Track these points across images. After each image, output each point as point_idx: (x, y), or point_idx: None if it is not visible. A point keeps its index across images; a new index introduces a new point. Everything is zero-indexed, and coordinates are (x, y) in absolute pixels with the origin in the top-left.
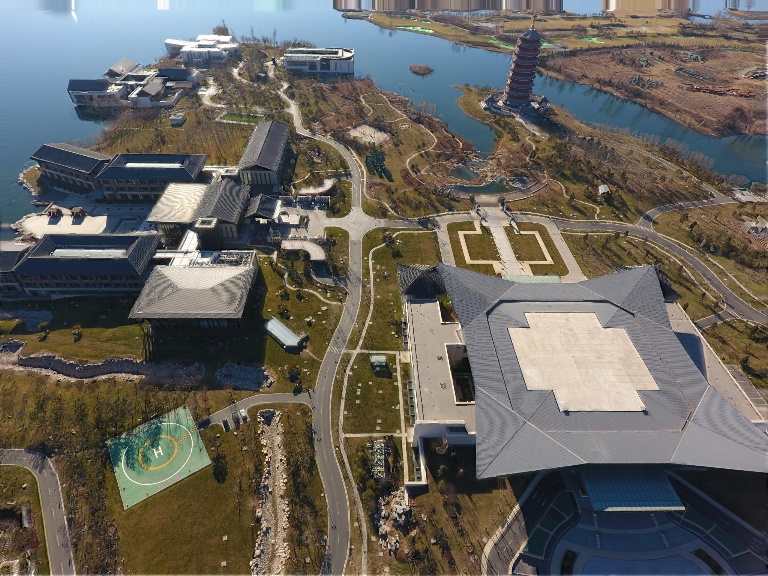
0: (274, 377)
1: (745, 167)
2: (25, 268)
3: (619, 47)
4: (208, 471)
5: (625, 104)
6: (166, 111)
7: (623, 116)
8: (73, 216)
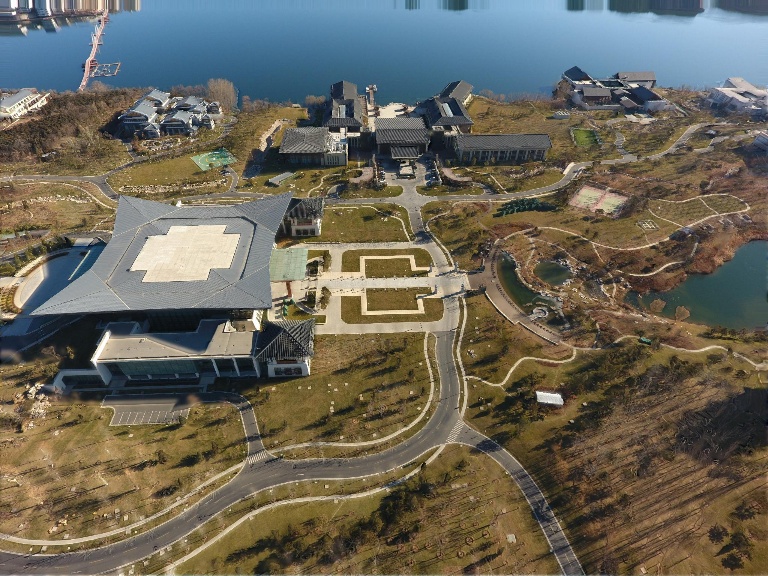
0: None
1: None
2: (328, 102)
3: None
4: None
5: None
6: (574, 110)
7: None
8: (404, 113)
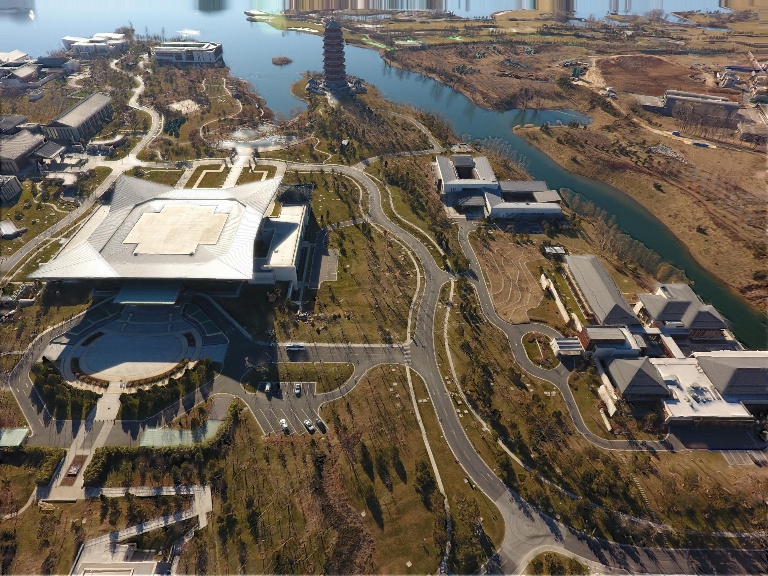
0: None
1: (495, 131)
2: None
3: (469, 43)
4: None
5: (444, 88)
6: (31, 90)
7: (444, 98)
8: None
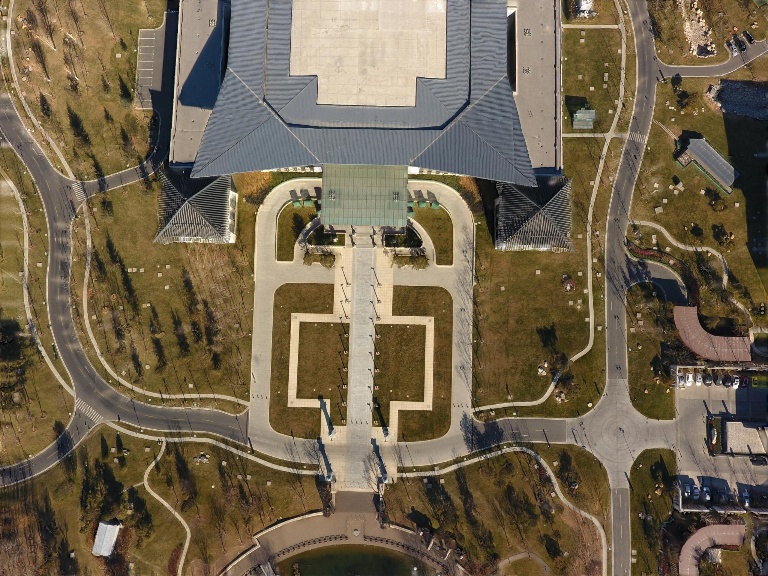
0: (708, 98)
1: None
2: None
3: None
4: None
5: None
6: None
7: None
8: None
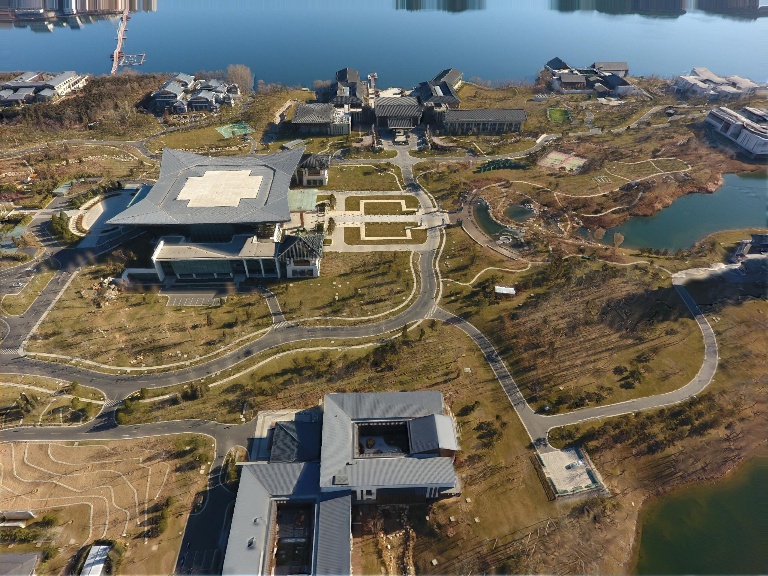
0: None
1: None
2: None
3: None
4: (223, 138)
5: None
6: (553, 94)
7: None
8: None
